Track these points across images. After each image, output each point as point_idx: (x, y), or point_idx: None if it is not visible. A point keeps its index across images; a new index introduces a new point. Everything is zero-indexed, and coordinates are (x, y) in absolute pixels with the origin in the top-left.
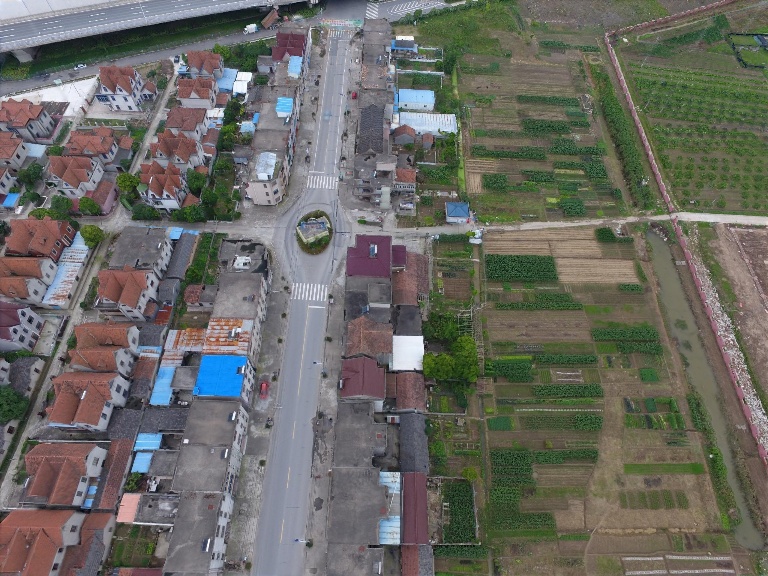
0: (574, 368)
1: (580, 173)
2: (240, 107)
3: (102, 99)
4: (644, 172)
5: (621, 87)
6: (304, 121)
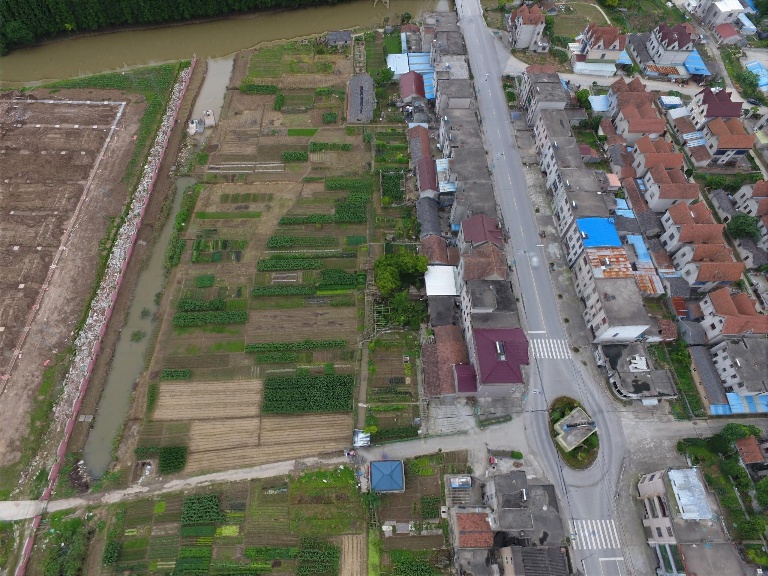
0: None
1: None
2: None
3: None
4: None
5: None
6: None
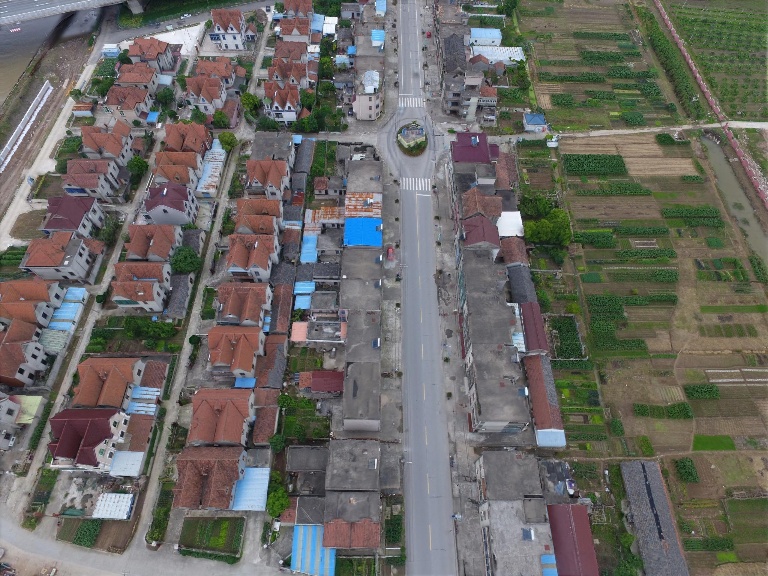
0: (649, 238)
1: (637, 92)
2: (332, 44)
3: (214, 38)
4: (694, 91)
5: (666, 24)
6: (388, 56)
